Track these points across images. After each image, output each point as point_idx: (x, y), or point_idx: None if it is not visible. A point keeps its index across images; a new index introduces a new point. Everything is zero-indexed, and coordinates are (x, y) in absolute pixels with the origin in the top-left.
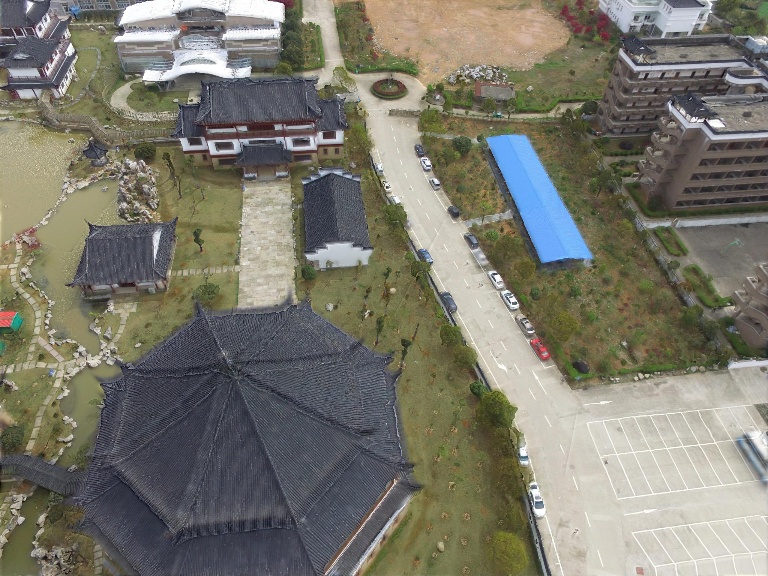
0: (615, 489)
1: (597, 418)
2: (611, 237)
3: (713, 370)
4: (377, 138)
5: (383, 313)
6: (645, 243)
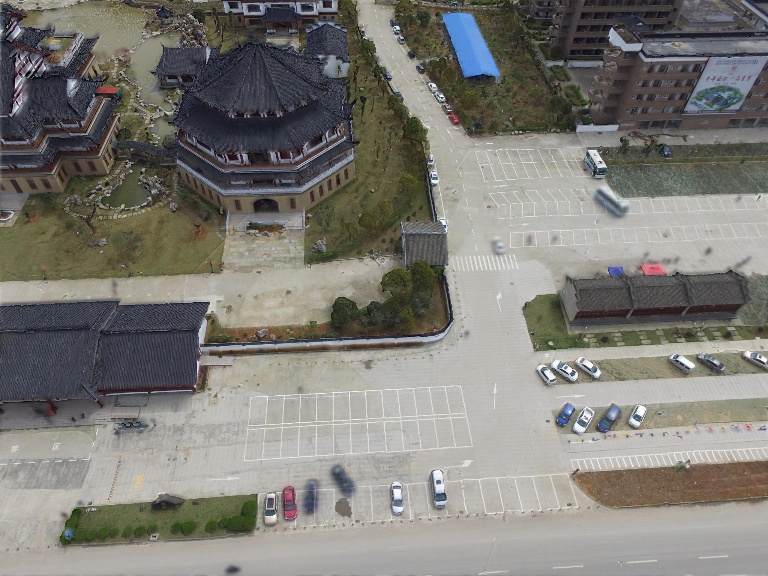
0: (485, 177)
1: (482, 149)
2: (519, 70)
3: (566, 132)
4: (364, 16)
5: (354, 99)
6: (542, 73)
